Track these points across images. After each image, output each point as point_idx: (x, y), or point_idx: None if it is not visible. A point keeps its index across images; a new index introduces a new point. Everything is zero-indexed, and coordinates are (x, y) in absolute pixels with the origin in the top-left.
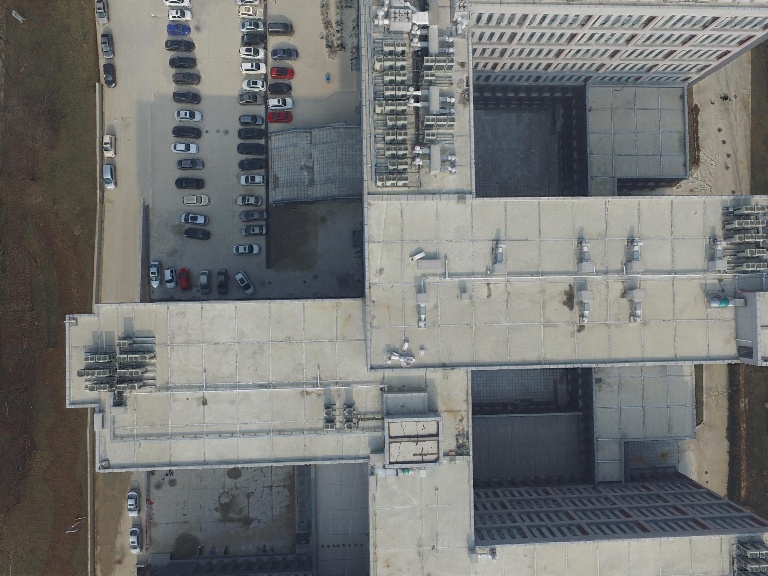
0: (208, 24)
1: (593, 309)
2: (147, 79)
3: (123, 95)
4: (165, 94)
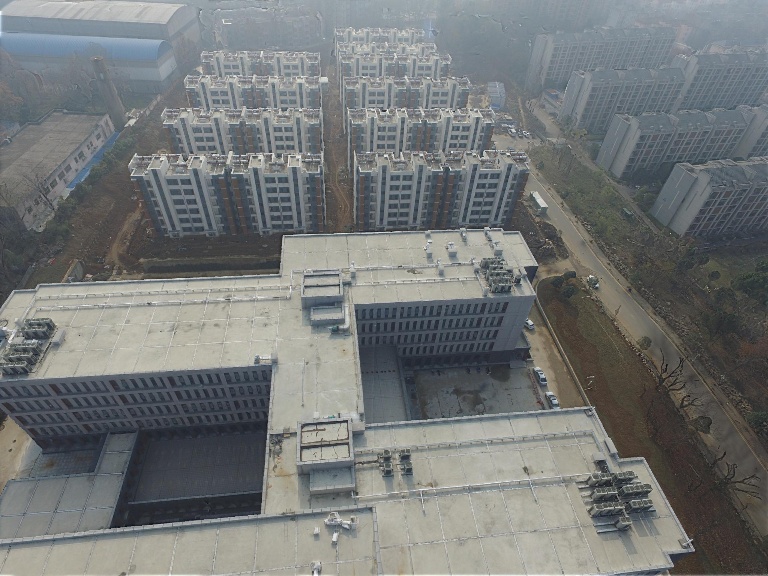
0: None
1: None
2: None
3: None
4: None
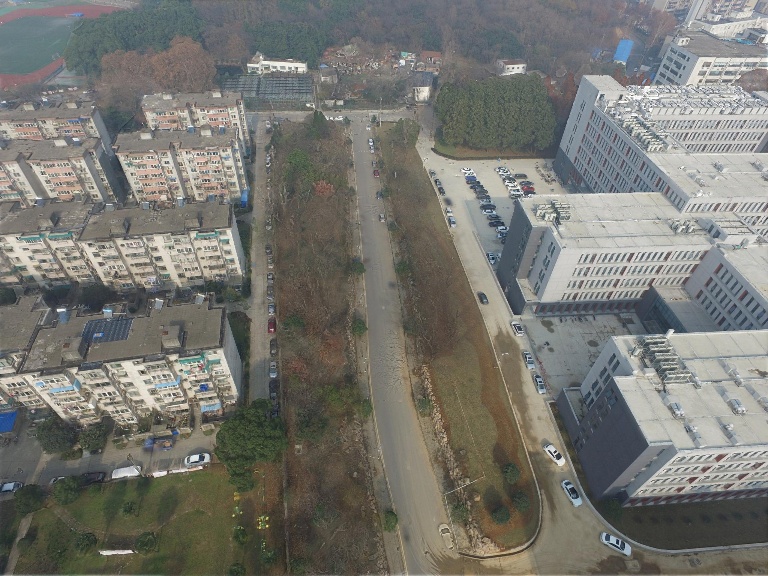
0: (484, 177)
1: None
2: (460, 193)
3: (450, 198)
4: (471, 197)
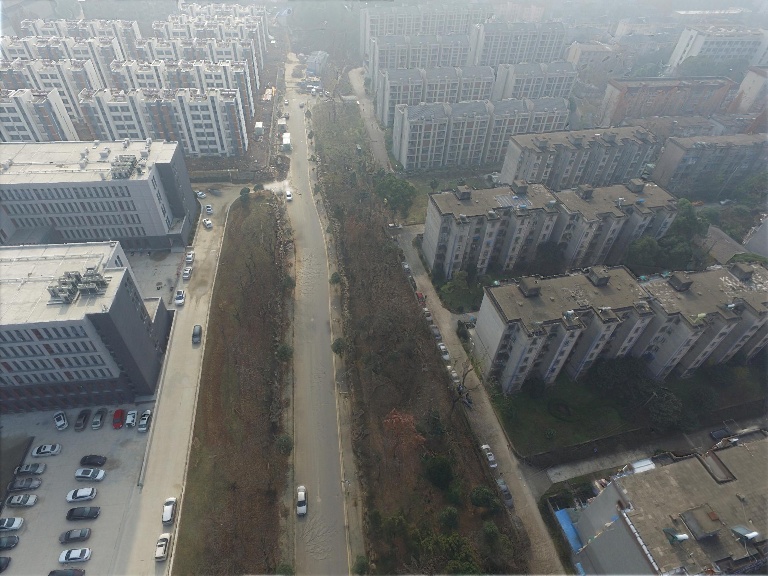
0: None
1: None
2: None
3: None
4: None
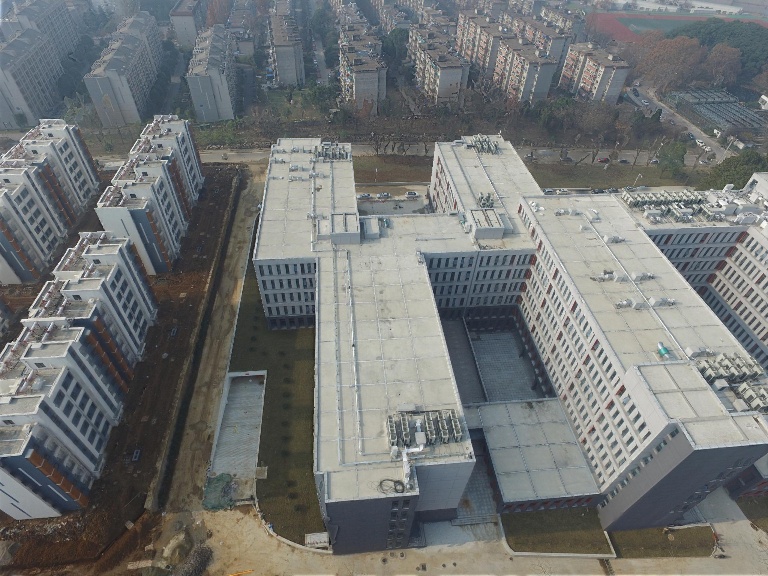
0: None
1: (610, 285)
2: None
3: None
4: None
